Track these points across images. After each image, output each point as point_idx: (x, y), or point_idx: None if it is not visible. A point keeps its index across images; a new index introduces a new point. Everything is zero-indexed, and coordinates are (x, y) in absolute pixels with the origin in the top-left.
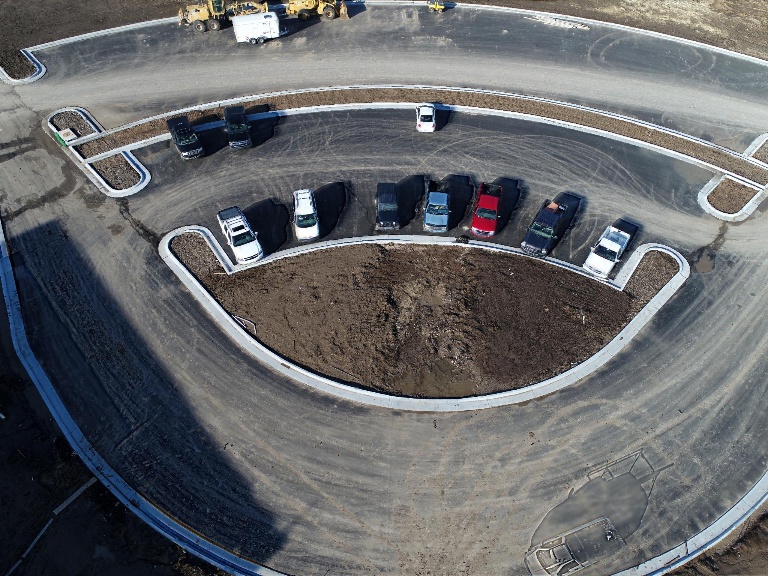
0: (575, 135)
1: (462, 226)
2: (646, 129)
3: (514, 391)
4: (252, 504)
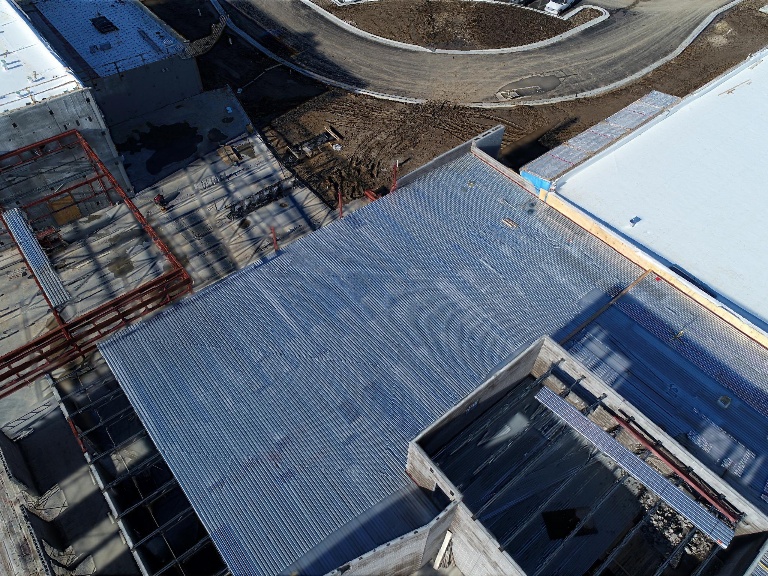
0: None
1: None
2: None
3: (497, 49)
4: (360, 75)
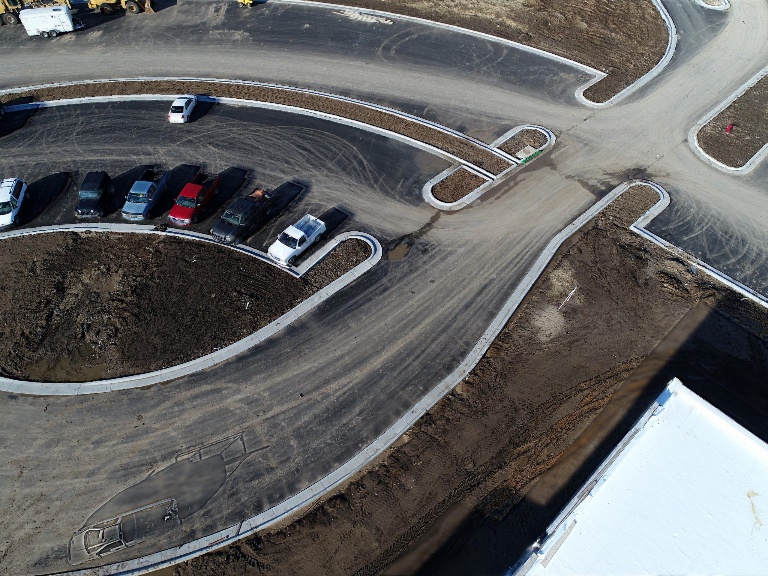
0: (330, 126)
1: (168, 214)
2: None
3: (141, 375)
4: None
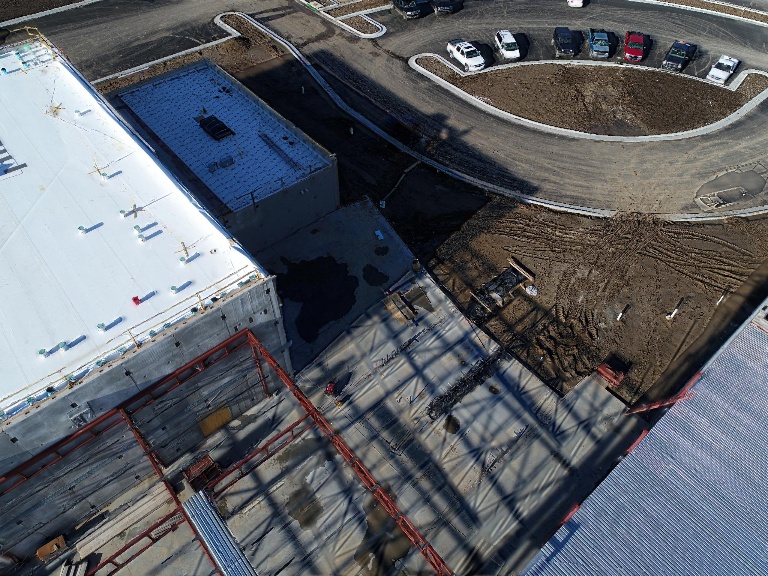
0: (686, 12)
1: (616, 57)
2: (739, 10)
3: (671, 134)
4: (520, 175)
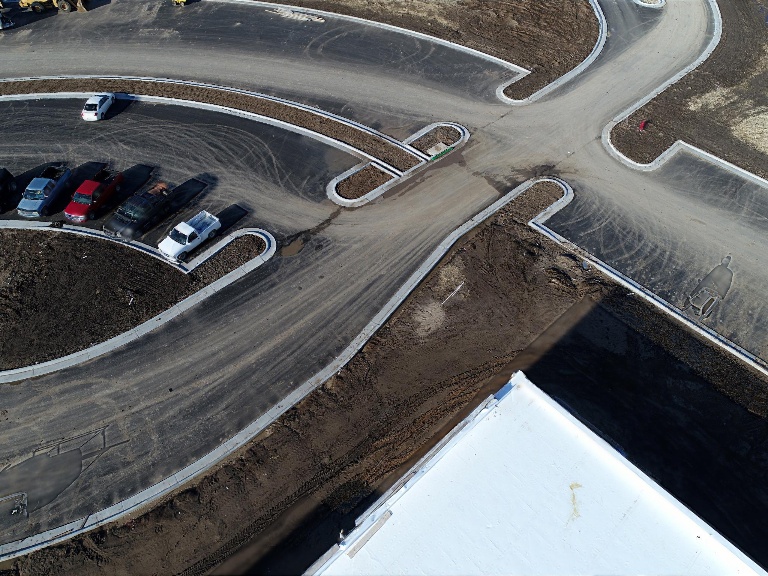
0: (244, 124)
1: None
2: (320, 118)
3: (12, 370)
4: None
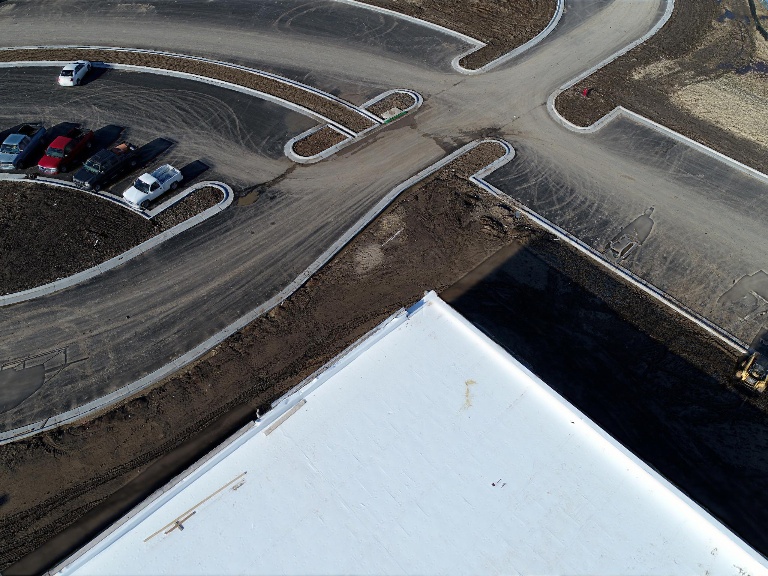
0: (212, 90)
1: None
2: (283, 85)
3: None
4: None
